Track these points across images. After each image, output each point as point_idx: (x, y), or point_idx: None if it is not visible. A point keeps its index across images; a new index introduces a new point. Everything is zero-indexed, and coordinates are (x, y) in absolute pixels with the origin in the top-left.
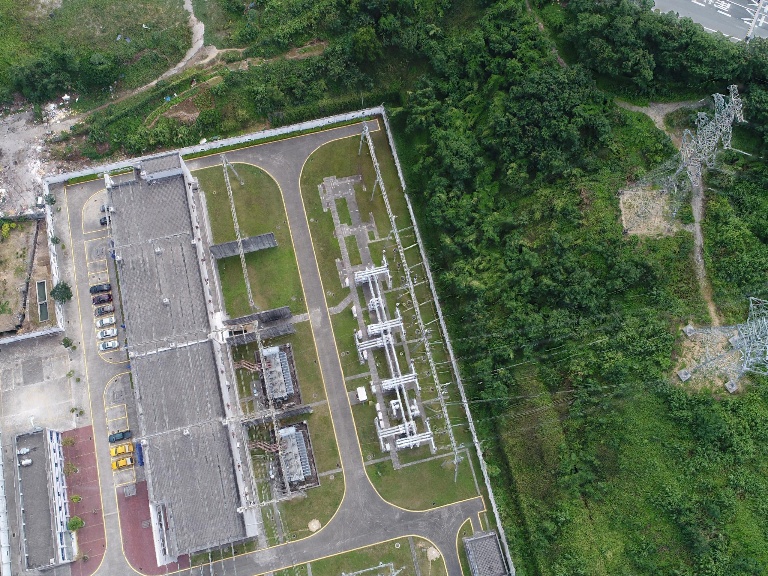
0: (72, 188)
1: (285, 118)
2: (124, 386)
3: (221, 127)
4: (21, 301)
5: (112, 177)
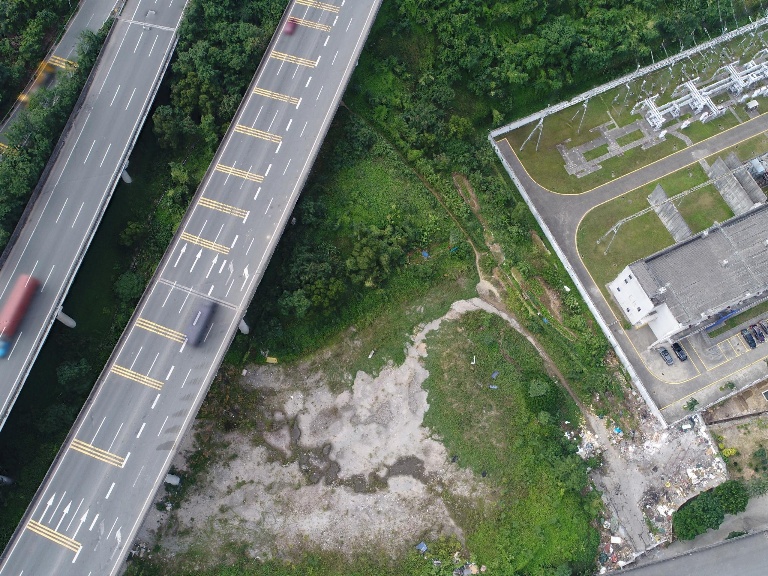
0: (659, 403)
1: None
2: None
3: None
4: None
5: (633, 367)
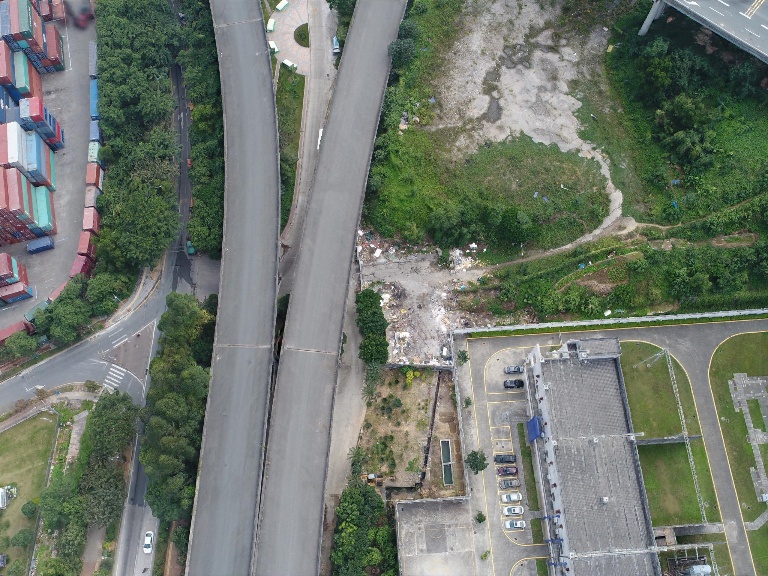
0: (474, 342)
1: (696, 303)
2: (530, 573)
3: (630, 302)
4: (422, 458)
5: (514, 337)
